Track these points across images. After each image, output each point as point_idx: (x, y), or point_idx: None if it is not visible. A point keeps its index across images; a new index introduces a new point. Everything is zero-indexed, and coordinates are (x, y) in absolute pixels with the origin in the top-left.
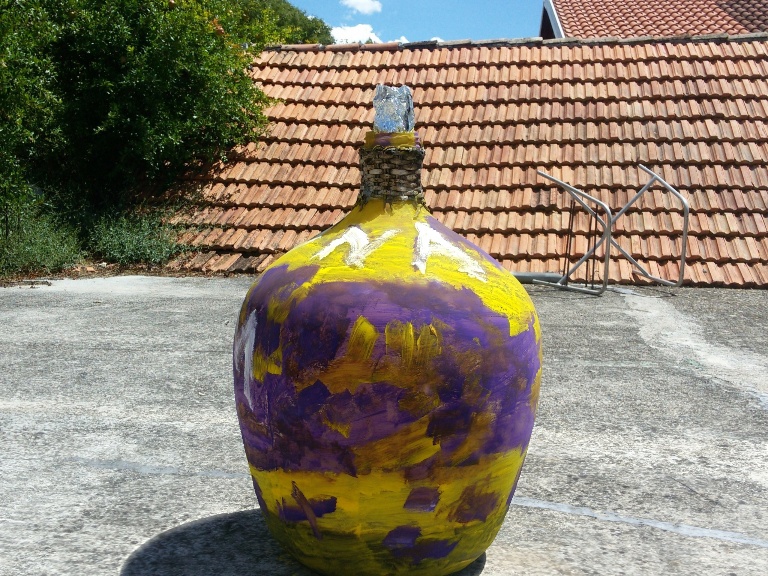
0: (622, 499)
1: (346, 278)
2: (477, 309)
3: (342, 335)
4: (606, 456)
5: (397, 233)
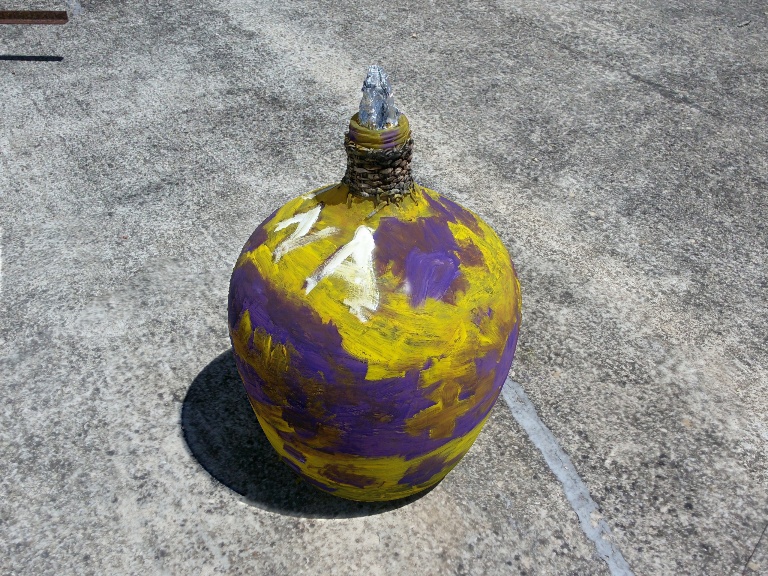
0: (651, 518)
1: (261, 267)
2: (332, 347)
3: (237, 316)
4: (758, 453)
5: (332, 234)
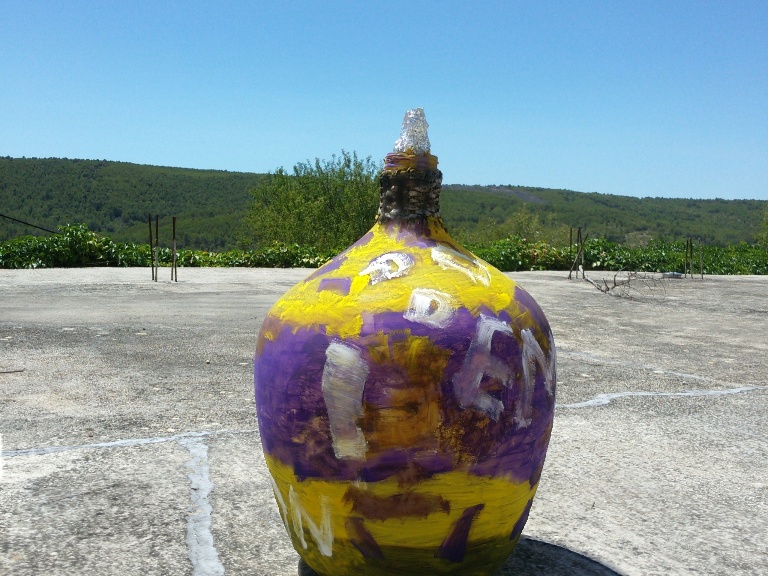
0: None
1: None
2: None
3: None
4: None
5: None
